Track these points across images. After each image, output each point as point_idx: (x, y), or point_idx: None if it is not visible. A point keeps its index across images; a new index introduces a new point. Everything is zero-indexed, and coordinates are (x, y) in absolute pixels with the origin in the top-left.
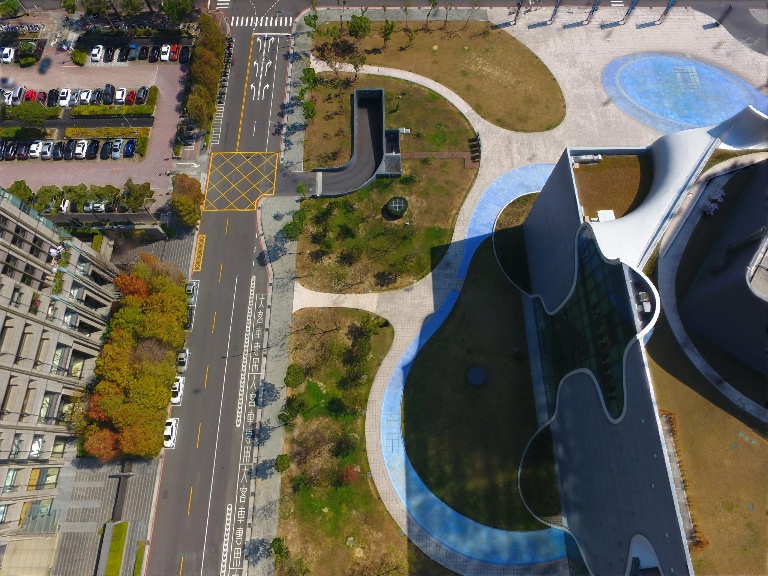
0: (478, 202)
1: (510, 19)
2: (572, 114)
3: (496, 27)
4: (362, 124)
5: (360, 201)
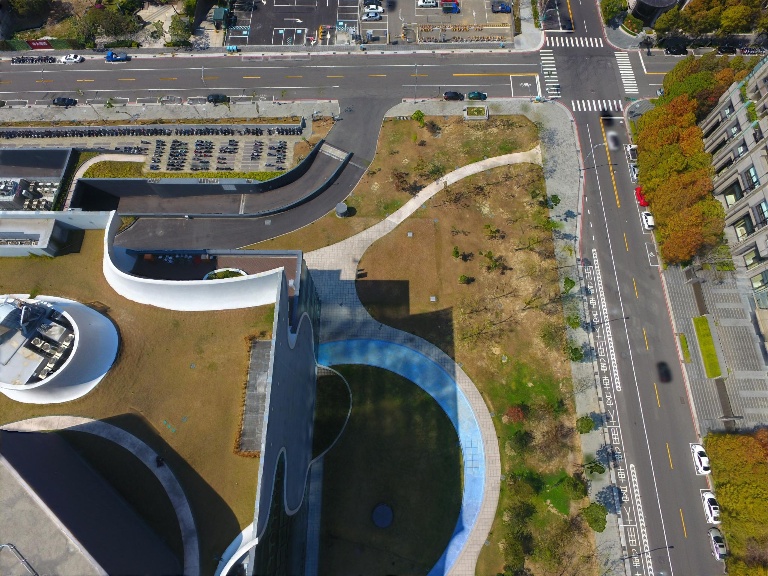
0: None
1: None
2: None
3: None
4: None
5: None
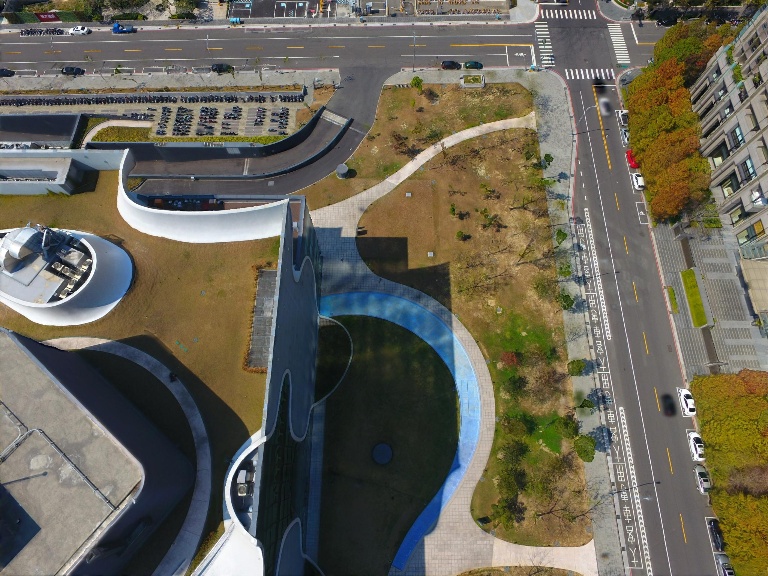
0: None
1: None
2: None
3: None
4: None
5: None
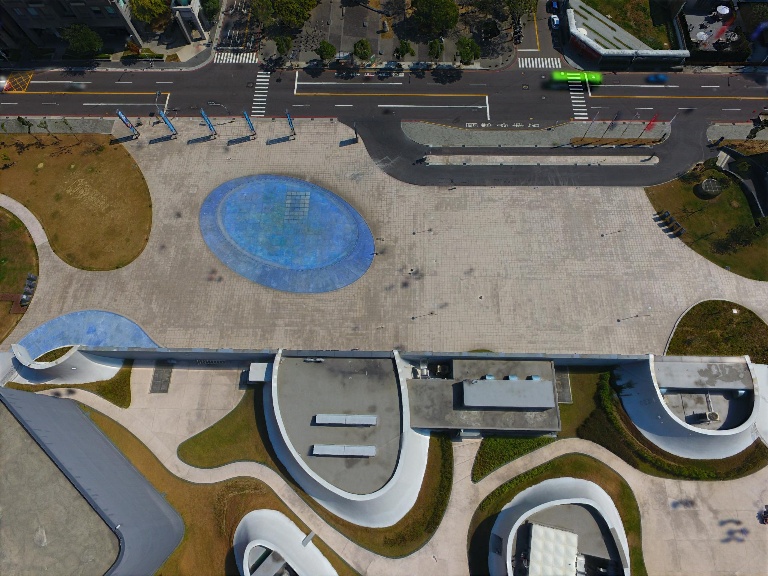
0: None
1: (134, 132)
2: (151, 249)
3: (115, 141)
4: None
5: None
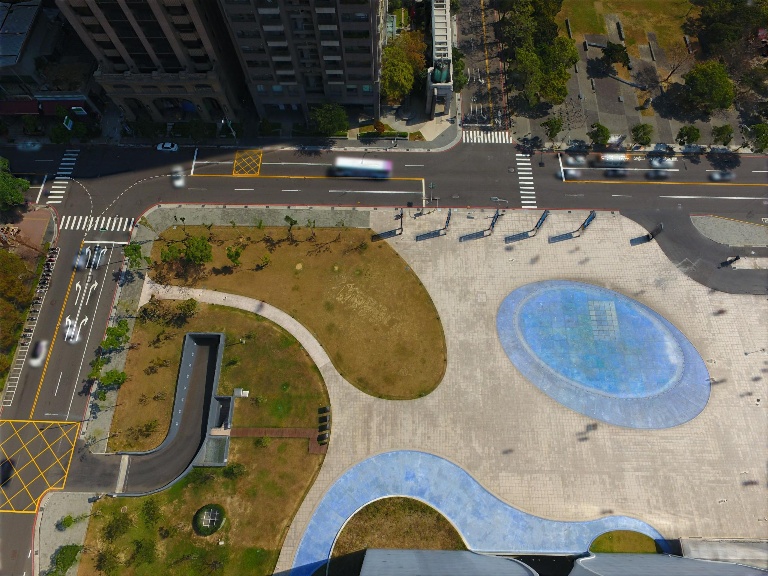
0: (317, 509)
1: (396, 226)
2: (453, 373)
3: (377, 238)
4: (198, 371)
5: (168, 503)
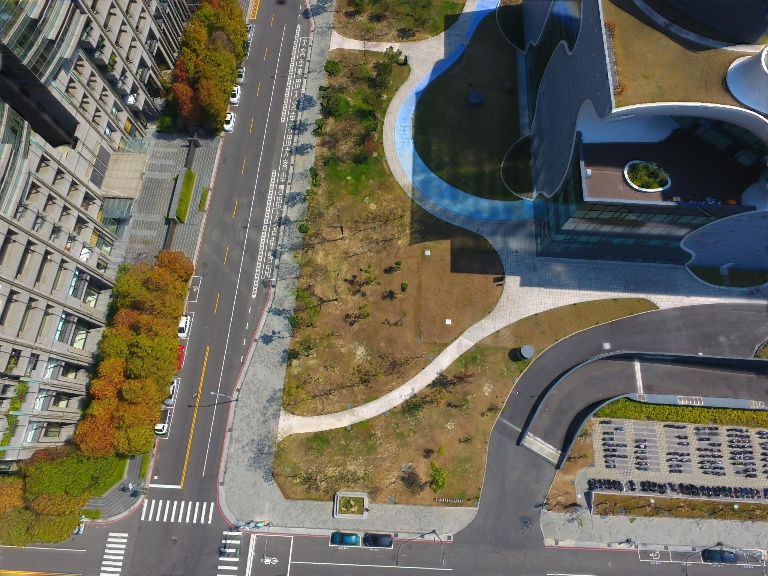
0: None
1: None
2: None
3: None
4: None
5: None
